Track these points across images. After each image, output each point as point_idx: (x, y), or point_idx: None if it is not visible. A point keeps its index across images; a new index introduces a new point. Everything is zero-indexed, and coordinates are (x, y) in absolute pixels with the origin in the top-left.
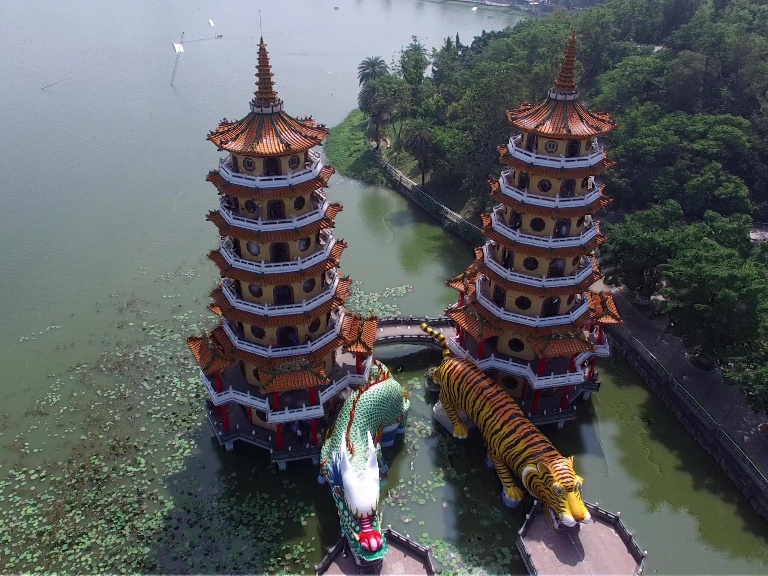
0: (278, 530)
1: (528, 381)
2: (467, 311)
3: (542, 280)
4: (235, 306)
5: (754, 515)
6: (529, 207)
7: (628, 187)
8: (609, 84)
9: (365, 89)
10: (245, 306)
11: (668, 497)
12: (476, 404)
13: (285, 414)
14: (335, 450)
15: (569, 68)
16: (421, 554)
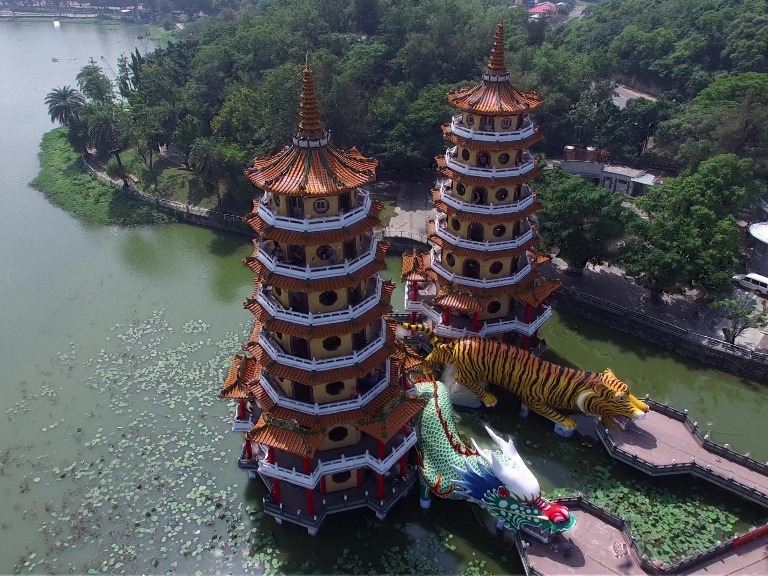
0: (440, 568)
1: (520, 332)
2: (454, 293)
3: (516, 241)
4: (315, 370)
5: (684, 358)
6: (501, 180)
7: (423, 157)
8: (345, 73)
9: (96, 123)
10: (328, 364)
11: (627, 375)
12: (506, 368)
13: (393, 456)
14: (450, 464)
15: (502, 52)
16: (574, 504)
